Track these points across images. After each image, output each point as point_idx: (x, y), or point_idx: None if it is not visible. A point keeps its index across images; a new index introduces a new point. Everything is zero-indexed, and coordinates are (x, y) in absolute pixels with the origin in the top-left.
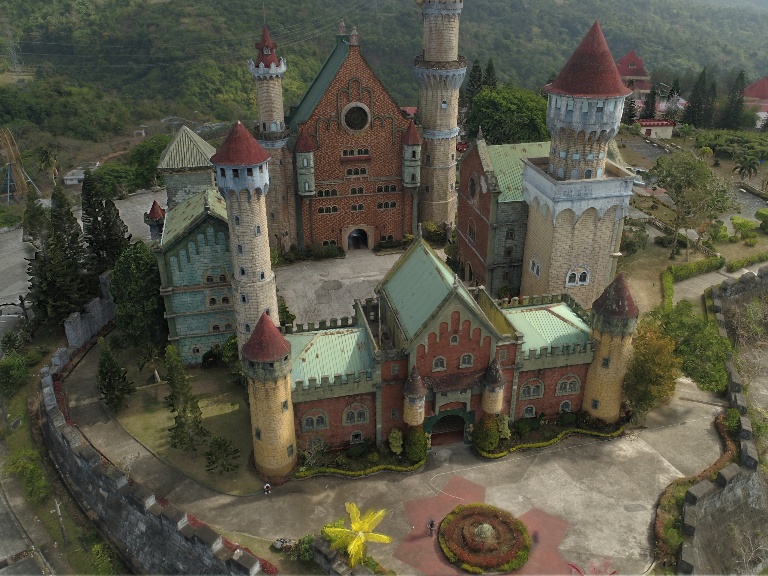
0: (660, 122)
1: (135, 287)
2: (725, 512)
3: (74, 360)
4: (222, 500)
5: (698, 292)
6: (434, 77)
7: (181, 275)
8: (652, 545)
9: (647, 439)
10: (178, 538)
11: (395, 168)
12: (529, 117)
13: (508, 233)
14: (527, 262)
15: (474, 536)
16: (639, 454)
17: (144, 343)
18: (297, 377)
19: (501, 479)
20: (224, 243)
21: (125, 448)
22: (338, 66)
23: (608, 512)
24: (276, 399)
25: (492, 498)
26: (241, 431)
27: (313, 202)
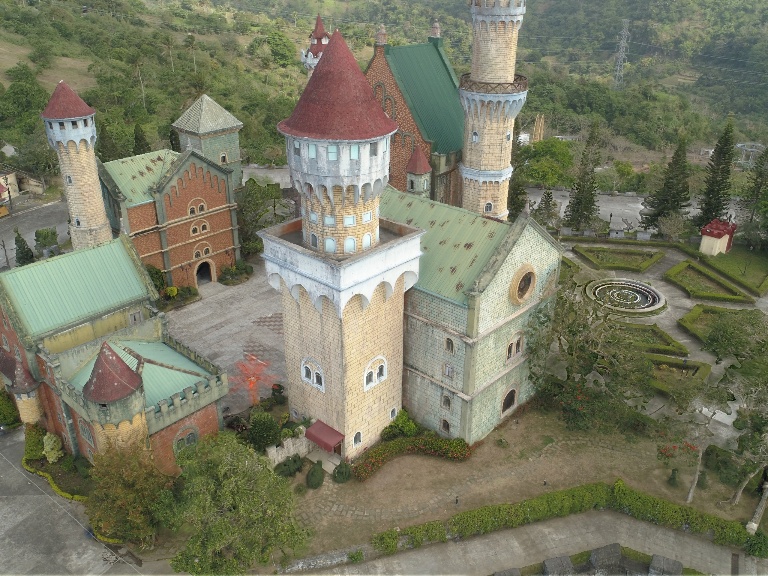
0: None
1: None
2: None
3: None
4: None
5: (620, 545)
6: None
7: None
8: None
9: (113, 571)
10: None
11: None
12: None
13: None
14: None
15: None
16: (76, 571)
17: None
18: None
19: None
20: None
21: None
22: None
23: None
24: None
25: None
26: None
27: None
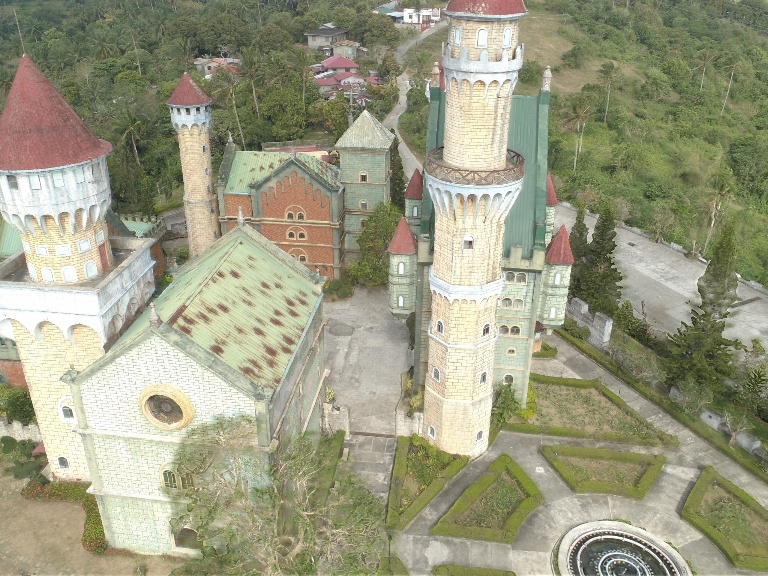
0: None
1: None
2: None
3: None
4: None
5: None
6: None
7: None
8: None
9: None
10: None
11: None
12: None
13: None
14: None
15: None
16: None
17: None
18: None
19: None
20: None
21: (187, 241)
22: None
23: None
24: None
25: None
26: None
27: None
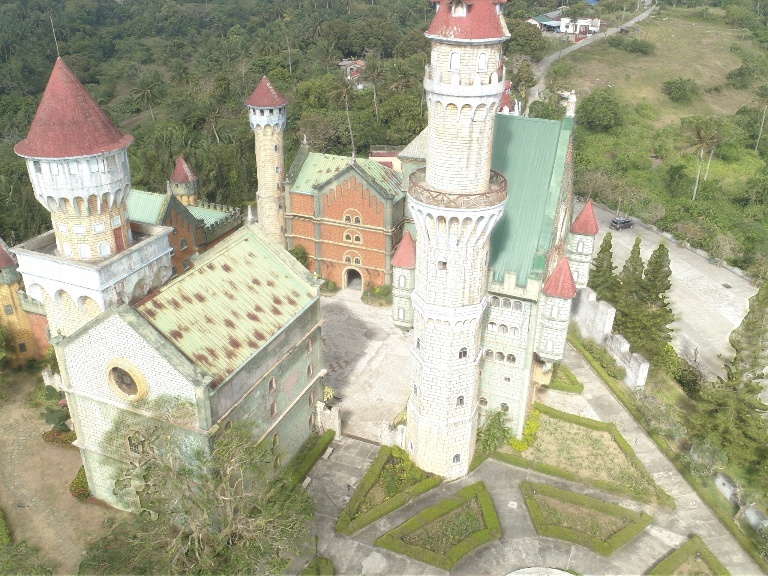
0: None
1: None
2: None
3: None
4: None
5: None
6: None
7: None
8: None
9: None
10: None
11: None
12: None
13: None
14: None
15: None
16: None
17: None
18: None
19: None
20: None
21: None
22: None
23: None
24: None
25: None
26: None
27: None
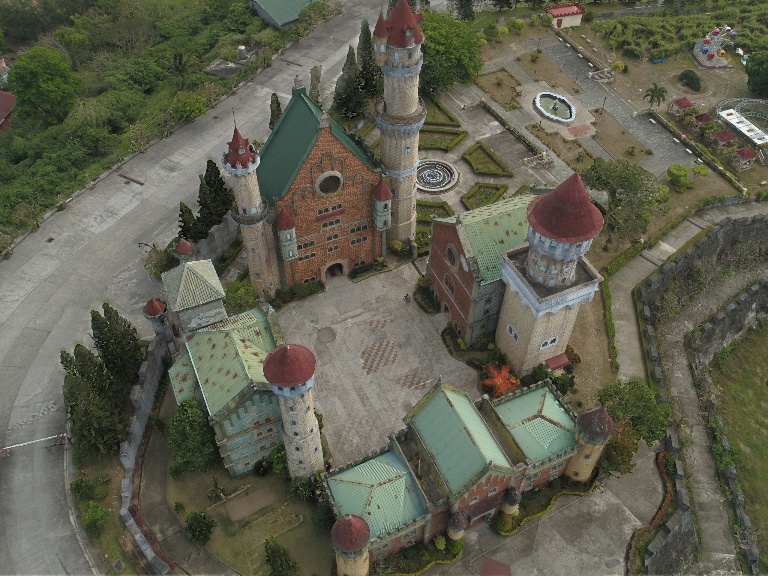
0: (570, 8)
1: (193, 443)
2: (668, 545)
3: (135, 481)
4: None
5: (628, 288)
6: None
7: (233, 428)
8: None
9: (612, 489)
10: None
11: (366, 212)
12: (457, 57)
13: (487, 301)
14: (504, 323)
15: None
16: (609, 507)
17: (202, 469)
18: None
19: (519, 554)
20: (268, 400)
21: None
22: (310, 145)
23: (596, 572)
24: (361, 561)
25: (516, 575)
26: (315, 546)
27: None
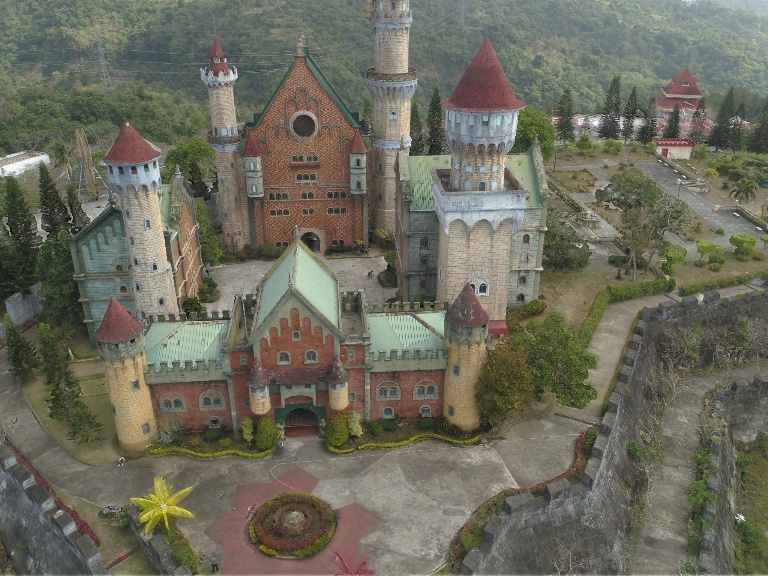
0: (679, 142)
1: (53, 271)
2: (551, 526)
3: None
4: (78, 468)
5: (634, 313)
6: (383, 89)
7: (93, 263)
8: (452, 548)
9: (500, 449)
10: (25, 496)
11: (344, 175)
12: (522, 132)
13: (422, 242)
14: (438, 271)
15: (284, 522)
16: (484, 463)
17: None
18: (154, 360)
19: (338, 473)
20: None
21: (18, 415)
22: (286, 76)
23: (425, 513)
24: (125, 378)
25: (320, 490)
26: None
27: (265, 204)
